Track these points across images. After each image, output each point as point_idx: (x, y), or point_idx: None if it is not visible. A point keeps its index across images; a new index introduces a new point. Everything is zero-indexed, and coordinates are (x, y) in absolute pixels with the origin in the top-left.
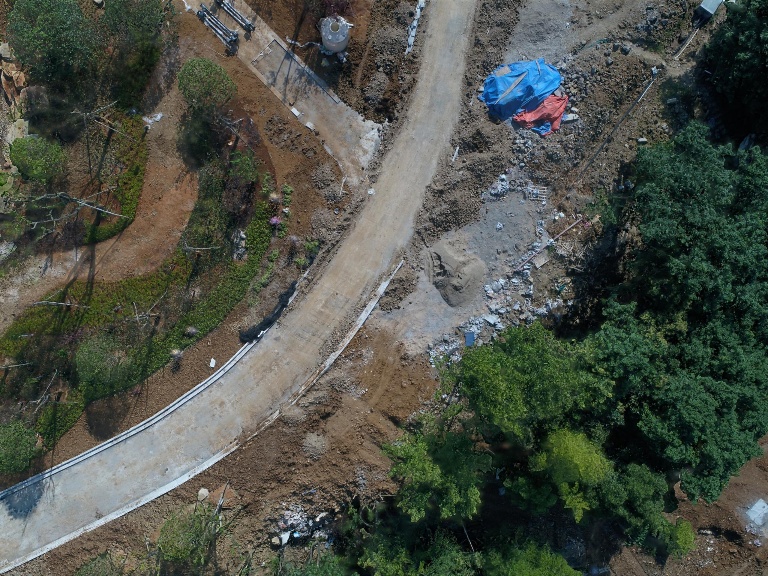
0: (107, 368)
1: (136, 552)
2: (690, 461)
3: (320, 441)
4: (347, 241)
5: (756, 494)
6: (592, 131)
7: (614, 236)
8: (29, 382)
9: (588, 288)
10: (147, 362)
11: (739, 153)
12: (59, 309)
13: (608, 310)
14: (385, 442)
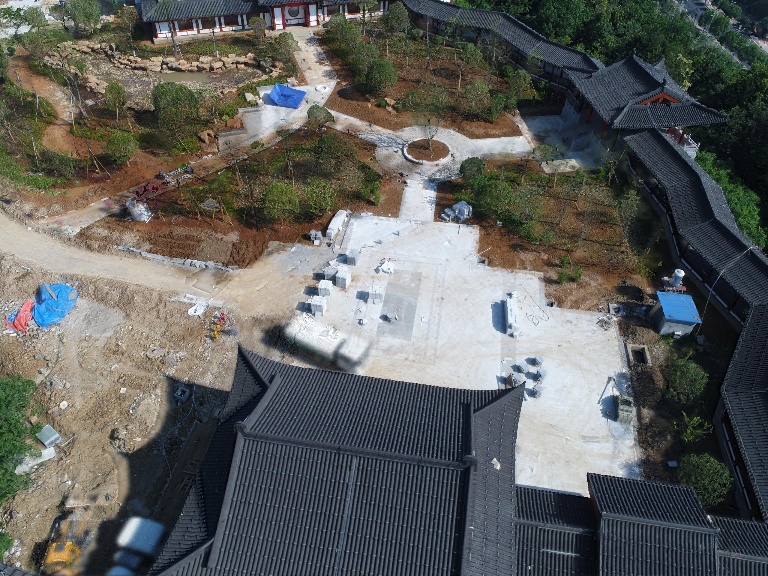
0: None
1: None
2: None
3: None
4: (4, 217)
5: None
6: None
7: None
8: (7, 98)
9: None
10: None
11: None
12: (44, 113)
13: None
14: None
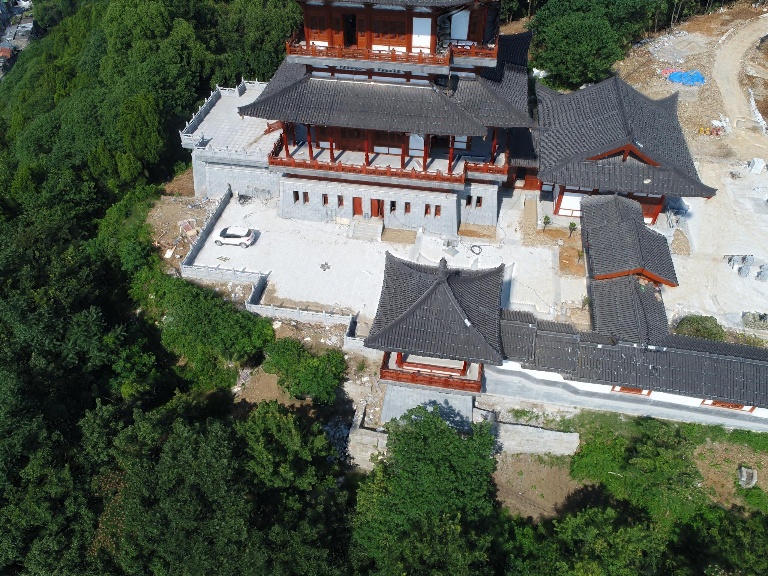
0: None
1: None
2: None
3: None
4: None
5: None
6: None
7: None
8: None
9: None
10: None
11: None
12: None
13: None
14: None
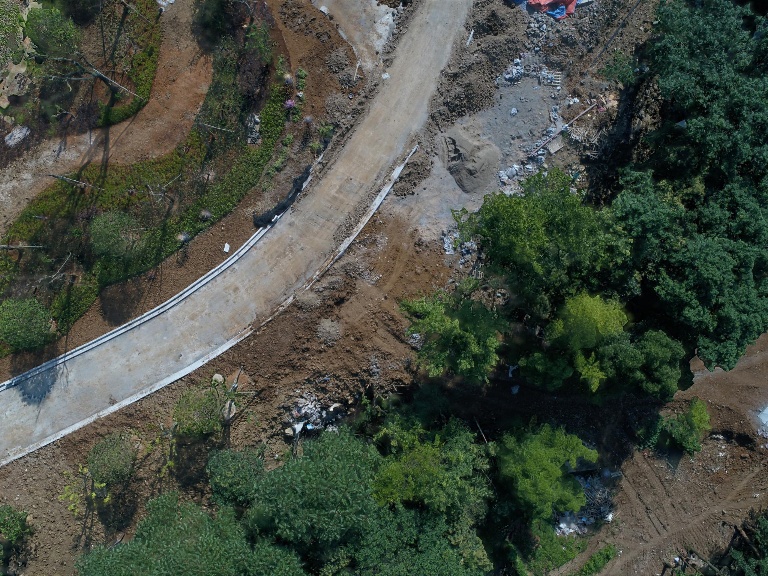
0: (123, 240)
1: (150, 437)
2: (707, 326)
3: (334, 327)
4: (361, 126)
5: (767, 397)
6: (607, 14)
7: (628, 122)
8: (43, 261)
9: (602, 177)
10: (161, 245)
11: (756, 18)
12: (73, 192)
13: (625, 178)
14: (399, 330)
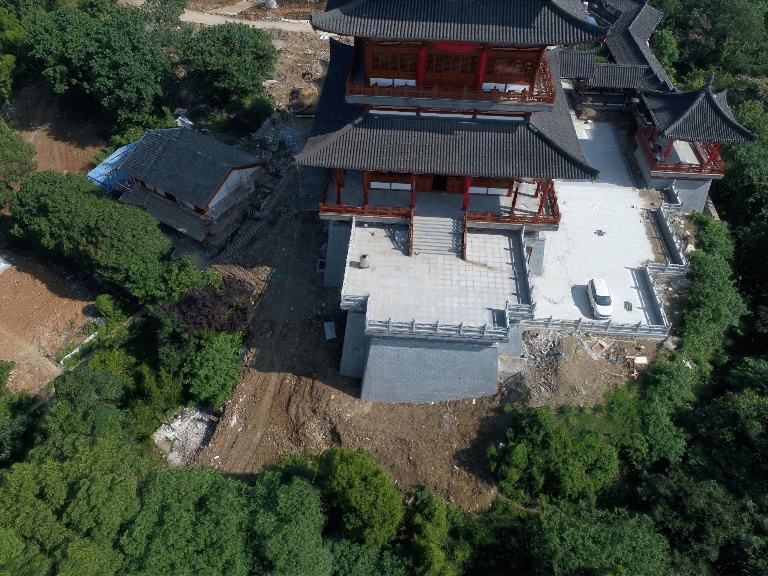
0: None
1: None
2: None
3: None
4: (187, 10)
5: None
6: None
7: None
8: None
9: None
10: None
11: None
12: None
13: None
14: None
